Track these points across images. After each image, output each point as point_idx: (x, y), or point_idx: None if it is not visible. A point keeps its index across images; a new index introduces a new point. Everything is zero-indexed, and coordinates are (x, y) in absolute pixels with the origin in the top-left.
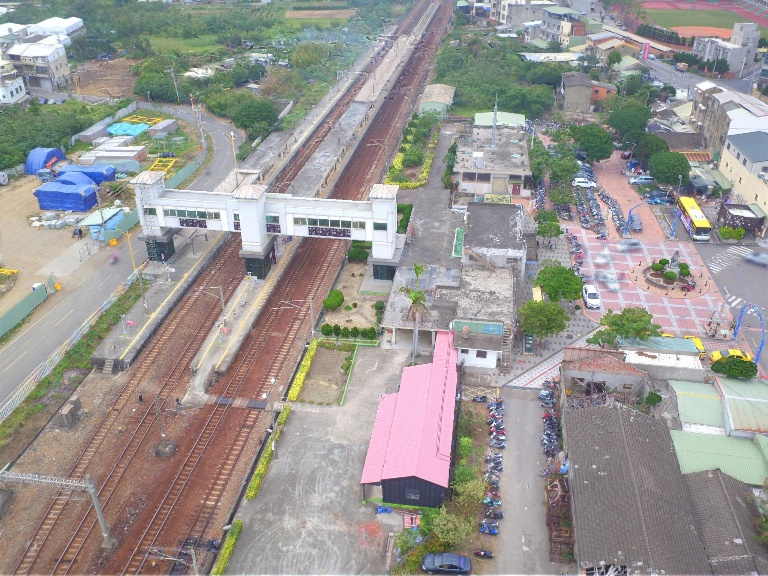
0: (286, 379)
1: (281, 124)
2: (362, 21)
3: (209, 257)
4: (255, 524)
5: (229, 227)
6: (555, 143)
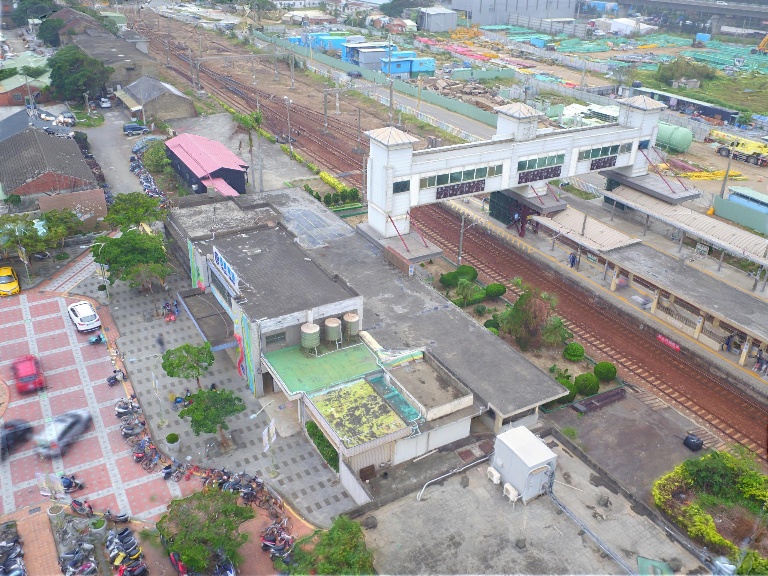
0: None
1: None
2: None
3: None
4: None
5: None
6: None
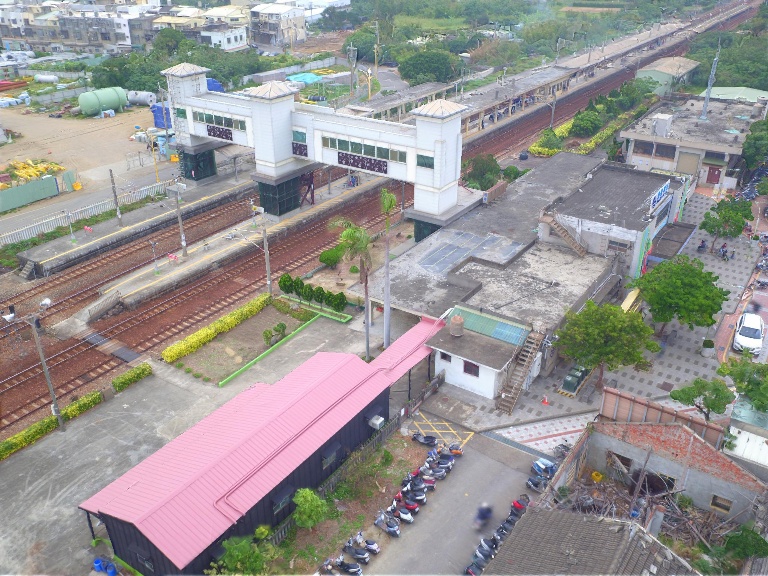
0: None
1: (462, 85)
2: (635, 10)
3: (250, 186)
4: None
5: None
6: None
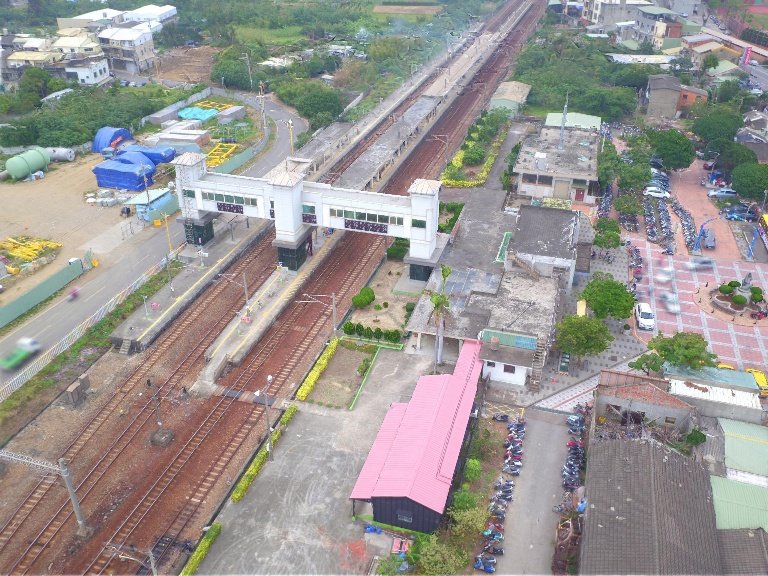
0: (300, 376)
1: (347, 115)
2: (448, 17)
3: (247, 244)
4: (235, 529)
5: (265, 214)
6: (630, 148)
